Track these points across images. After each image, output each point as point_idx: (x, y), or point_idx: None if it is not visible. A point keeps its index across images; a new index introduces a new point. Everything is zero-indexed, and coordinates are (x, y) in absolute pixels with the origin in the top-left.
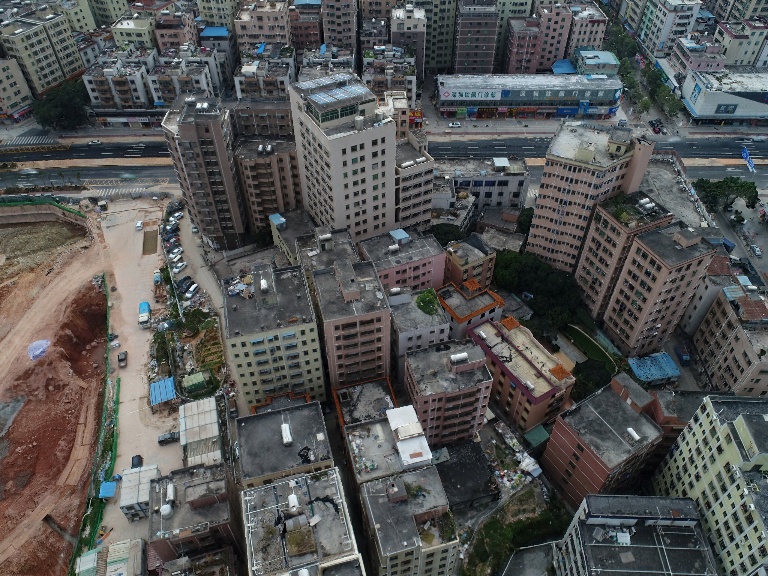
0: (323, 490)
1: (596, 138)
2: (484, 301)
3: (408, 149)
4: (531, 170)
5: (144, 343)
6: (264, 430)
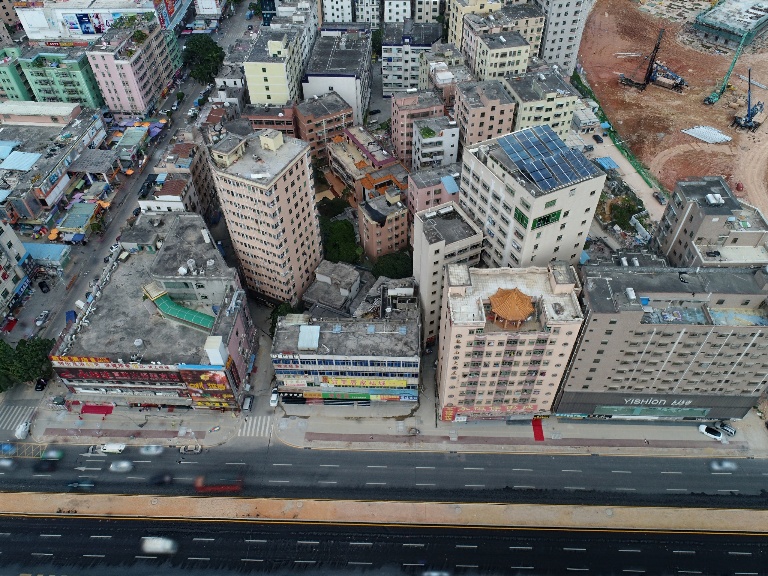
0: (481, 25)
1: (244, 168)
2: (378, 176)
3: (445, 239)
4: (225, 484)
5: (654, 213)
6: (515, 45)
